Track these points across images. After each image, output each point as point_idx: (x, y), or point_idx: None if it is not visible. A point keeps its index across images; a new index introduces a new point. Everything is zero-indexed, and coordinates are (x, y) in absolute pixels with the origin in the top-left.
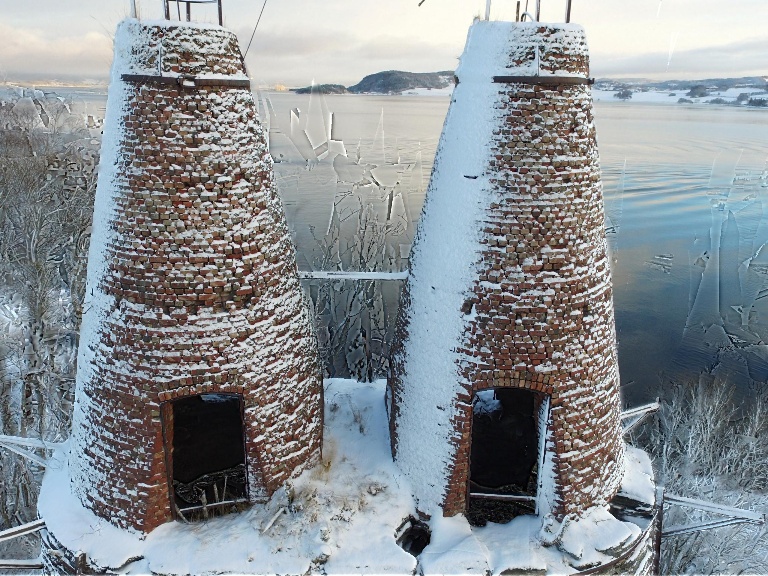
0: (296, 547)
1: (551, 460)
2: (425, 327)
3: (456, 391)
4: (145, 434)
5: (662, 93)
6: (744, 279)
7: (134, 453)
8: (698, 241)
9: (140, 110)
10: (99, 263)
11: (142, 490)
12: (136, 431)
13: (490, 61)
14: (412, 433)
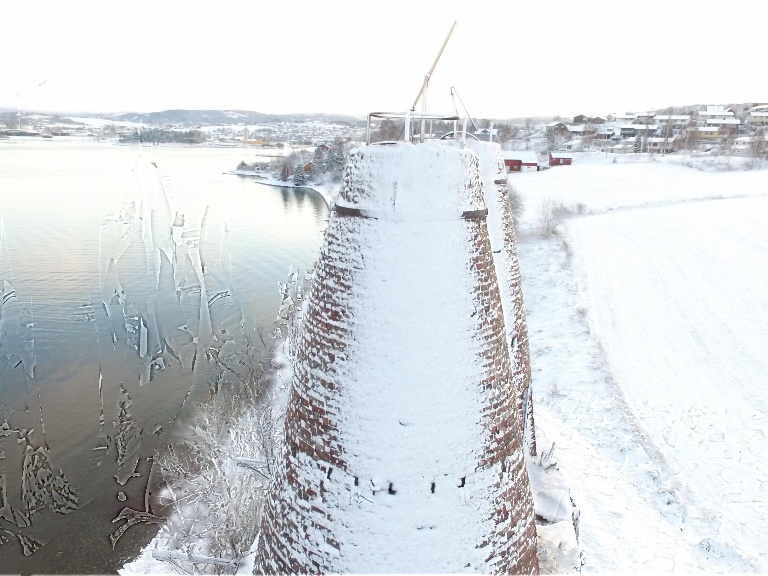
0: (566, 570)
1: None
2: None
3: None
4: None
5: (20, 144)
6: (180, 302)
7: None
8: (109, 282)
9: (485, 248)
10: (476, 439)
11: None
12: None
13: (491, 169)
14: None
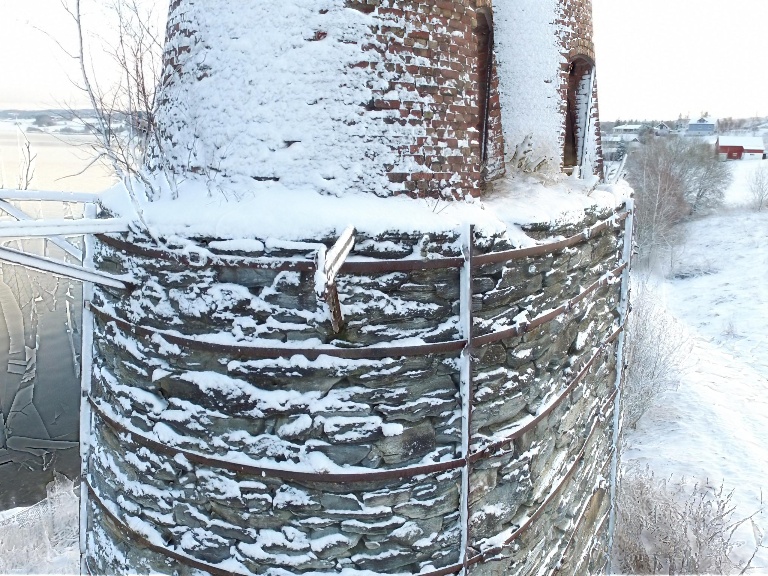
0: None
1: (594, 125)
2: (521, 7)
3: (559, 61)
4: (468, 54)
5: None
6: None
7: (460, 83)
8: None
9: None
10: None
11: (473, 137)
12: (458, 50)
13: None
14: (522, 118)
